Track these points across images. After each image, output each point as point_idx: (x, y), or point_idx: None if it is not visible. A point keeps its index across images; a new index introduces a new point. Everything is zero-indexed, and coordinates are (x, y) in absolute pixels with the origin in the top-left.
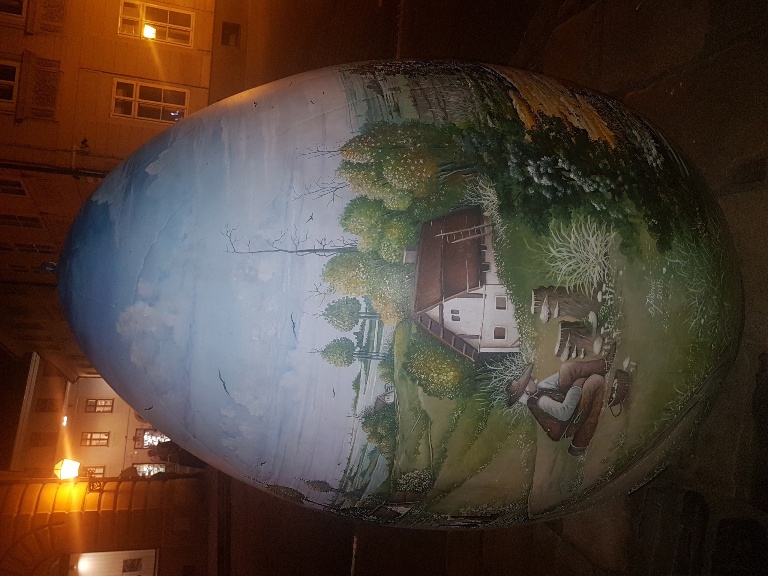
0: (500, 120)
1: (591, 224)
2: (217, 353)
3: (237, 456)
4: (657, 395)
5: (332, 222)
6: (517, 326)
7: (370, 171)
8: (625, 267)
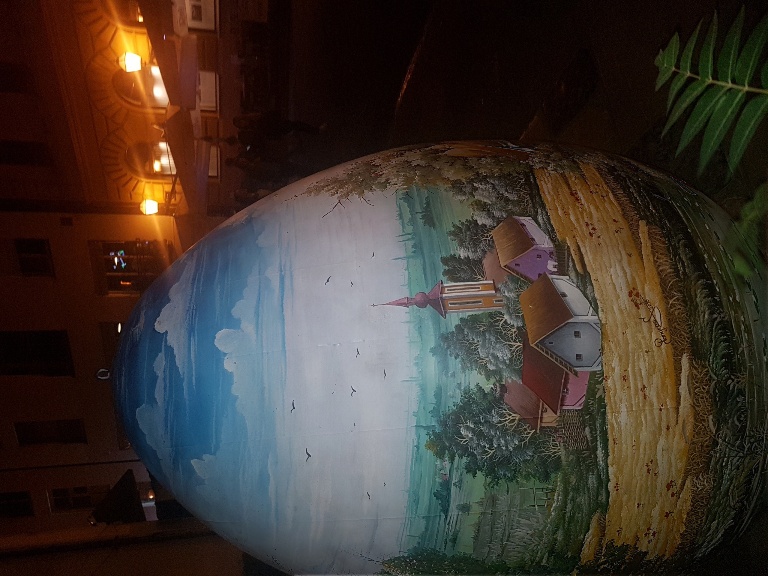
0: (557, 558)
1: None
2: None
3: None
4: None
5: None
6: None
7: None
8: None
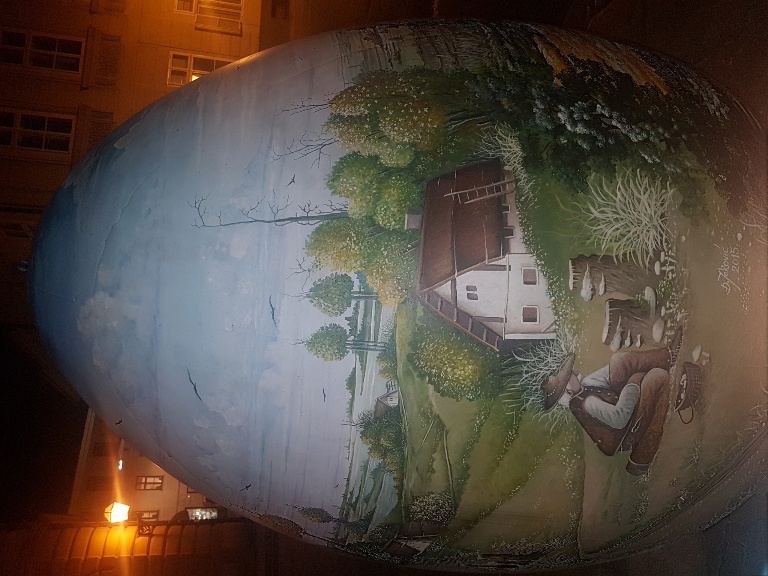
0: (522, 64)
1: (642, 179)
2: (185, 349)
3: (218, 478)
4: (739, 396)
5: (317, 184)
6: (552, 305)
7: (364, 124)
8: (688, 231)
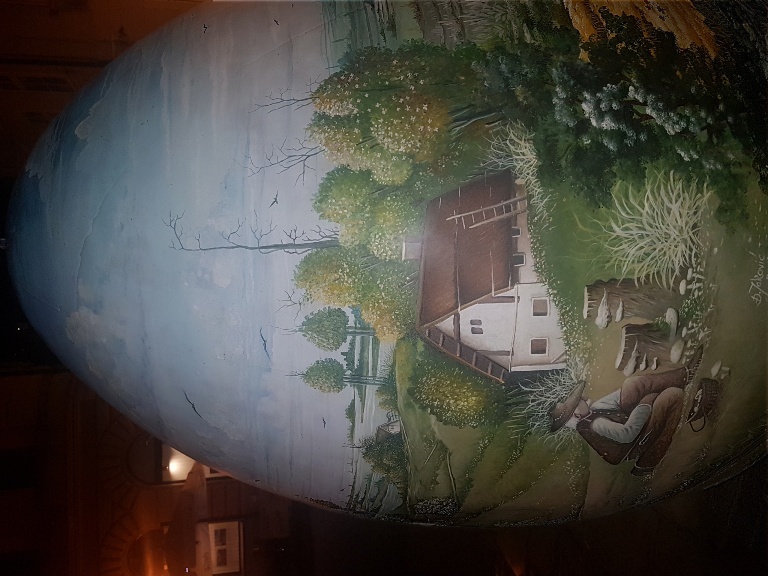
0: (543, 30)
1: (675, 183)
2: (179, 372)
3: (228, 471)
4: (756, 401)
5: (303, 206)
6: (563, 336)
7: (353, 127)
8: (722, 241)
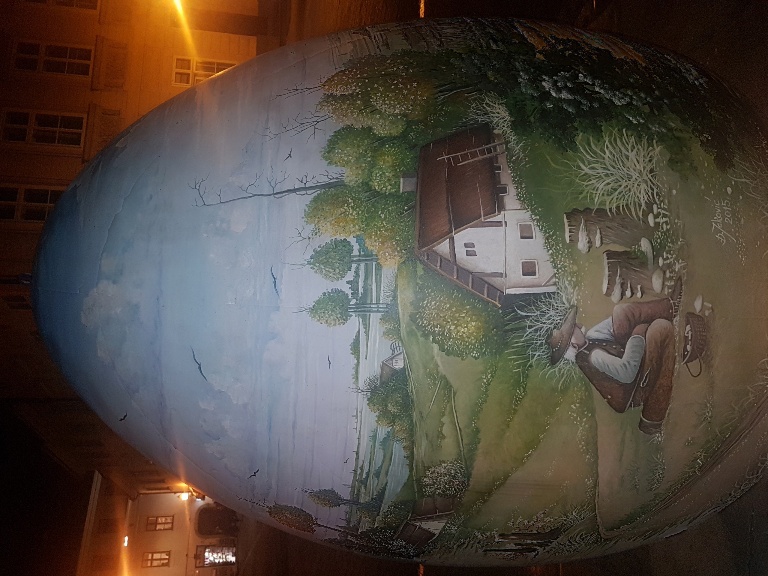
0: (505, 43)
1: (628, 138)
2: (189, 328)
3: (225, 466)
4: (746, 349)
5: (314, 157)
6: (550, 259)
7: (356, 100)
8: (678, 185)
